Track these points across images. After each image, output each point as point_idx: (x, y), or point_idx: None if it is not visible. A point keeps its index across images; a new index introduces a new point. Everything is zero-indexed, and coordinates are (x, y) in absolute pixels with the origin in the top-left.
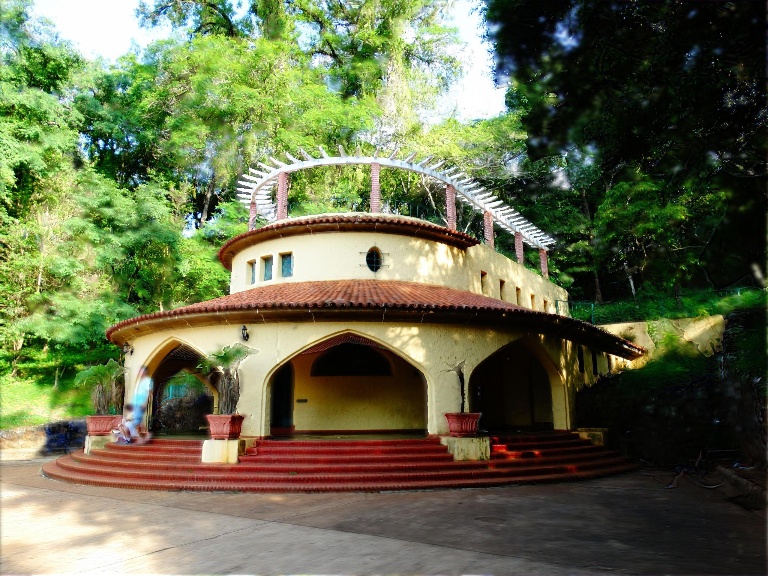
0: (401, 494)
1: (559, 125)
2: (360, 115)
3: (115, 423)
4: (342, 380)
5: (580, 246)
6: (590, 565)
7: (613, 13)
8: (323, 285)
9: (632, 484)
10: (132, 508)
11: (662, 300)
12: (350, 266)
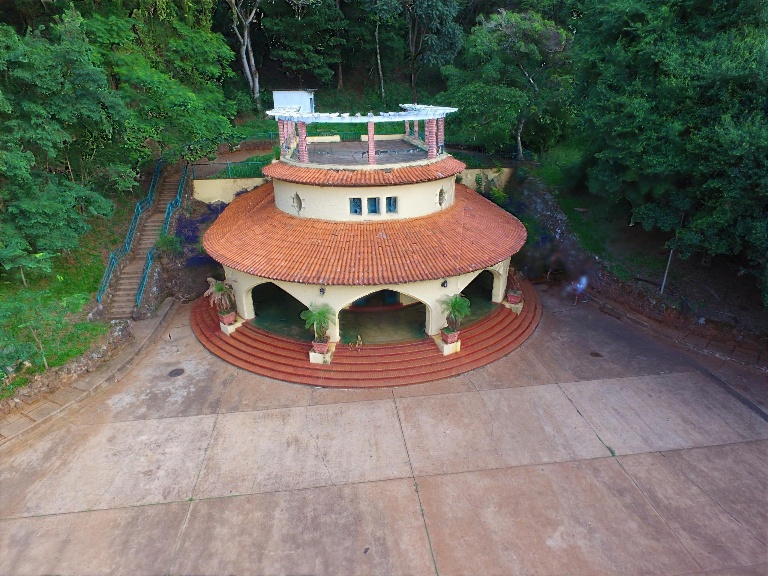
0: (529, 343)
1: None
2: None
3: (227, 320)
4: None
5: (339, 42)
6: (659, 372)
7: (698, 196)
8: (435, 228)
9: (559, 304)
10: (489, 396)
11: (398, 100)
12: (431, 205)
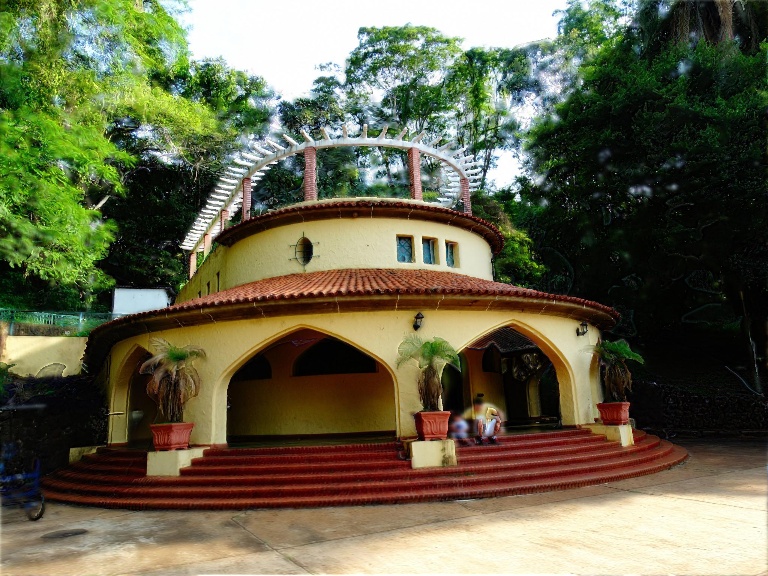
0: None
1: (697, 242)
2: (186, 47)
3: (176, 437)
4: (496, 376)
5: None
6: None
7: None
8: None
9: None
10: (758, 472)
11: None
12: (488, 272)
